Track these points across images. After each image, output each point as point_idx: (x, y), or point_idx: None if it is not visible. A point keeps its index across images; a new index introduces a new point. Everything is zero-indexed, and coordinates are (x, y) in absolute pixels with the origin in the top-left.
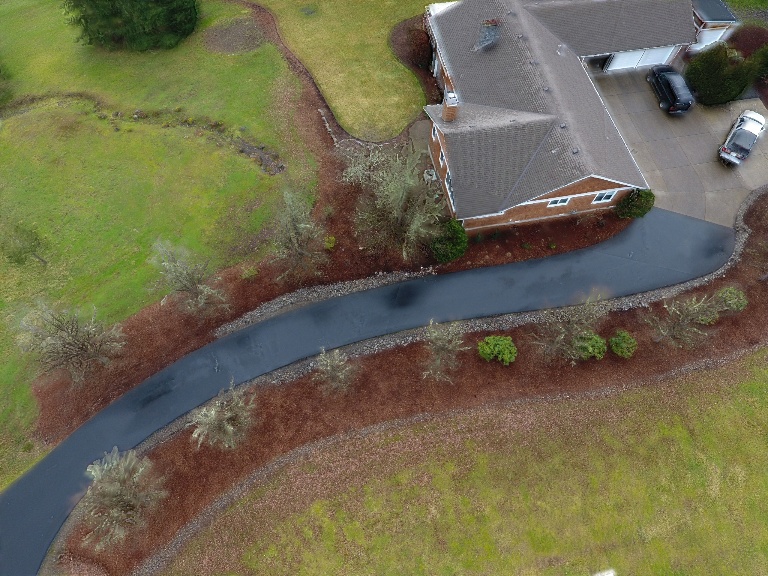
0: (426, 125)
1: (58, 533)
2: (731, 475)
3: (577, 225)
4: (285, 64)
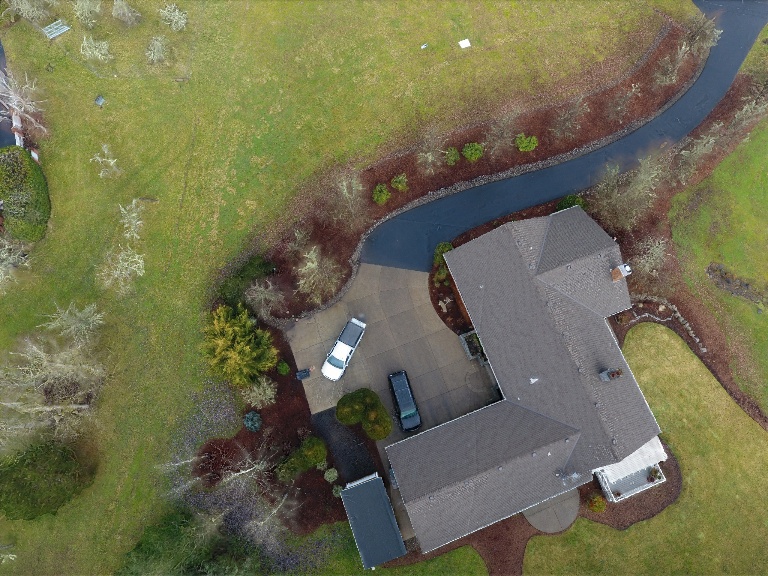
0: None
1: None
2: (401, 94)
3: None
4: (764, 412)
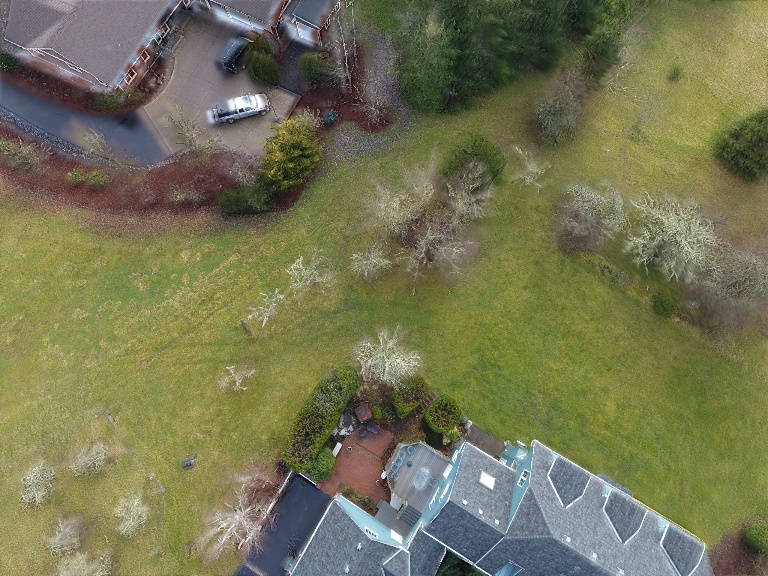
0: None
1: None
2: None
3: (93, 93)
4: None
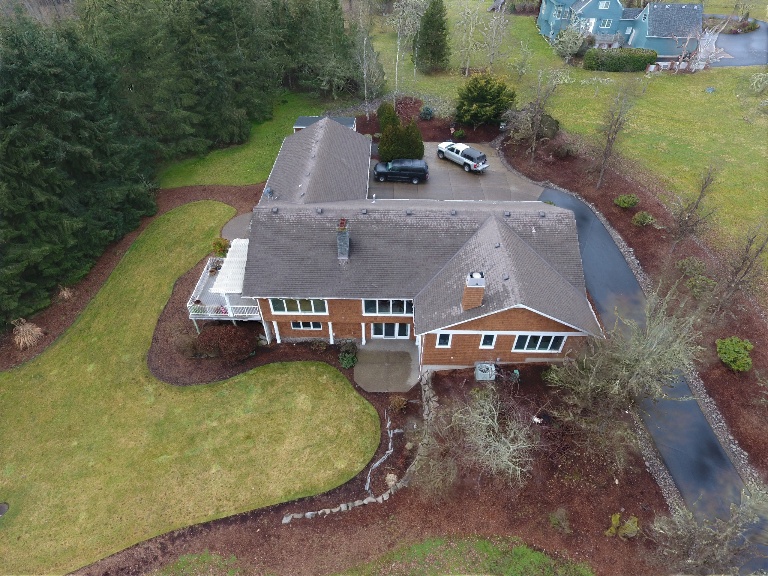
0: (364, 370)
1: None
2: None
3: None
4: None
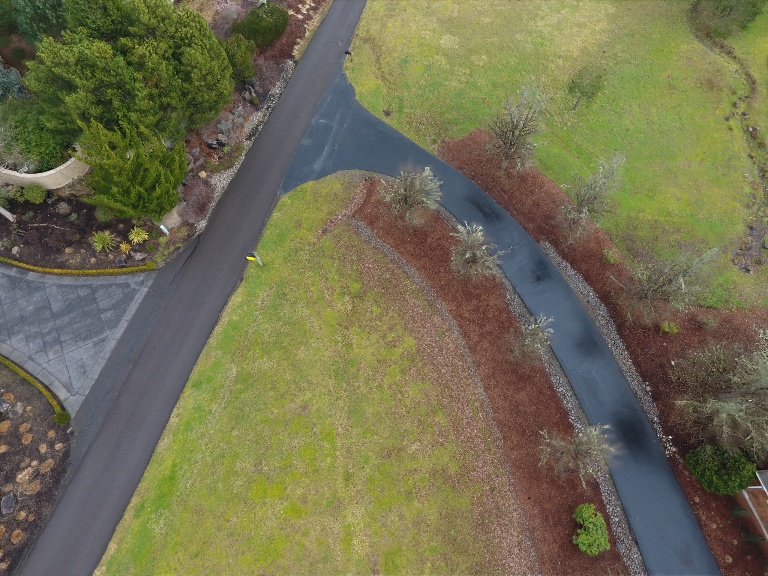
0: None
1: (381, 174)
2: None
3: None
4: None
